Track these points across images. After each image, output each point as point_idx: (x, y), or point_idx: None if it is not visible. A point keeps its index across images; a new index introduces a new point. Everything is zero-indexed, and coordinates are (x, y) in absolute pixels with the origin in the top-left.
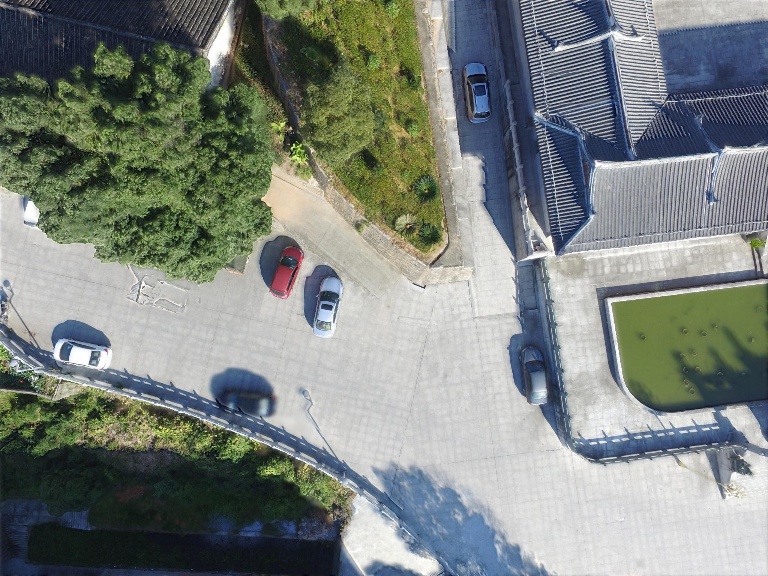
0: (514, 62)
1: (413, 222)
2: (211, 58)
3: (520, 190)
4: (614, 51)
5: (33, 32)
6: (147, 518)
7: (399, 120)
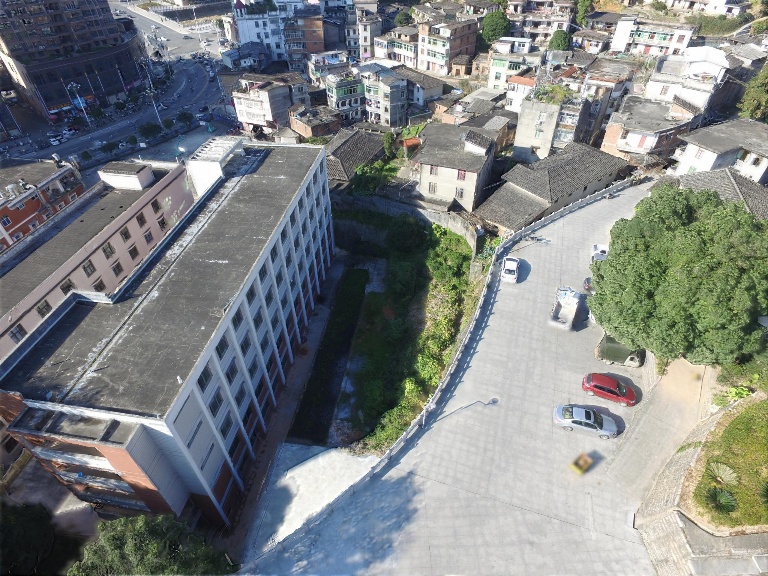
0: None
1: (728, 483)
2: None
3: None
4: None
5: None
6: (370, 320)
7: None
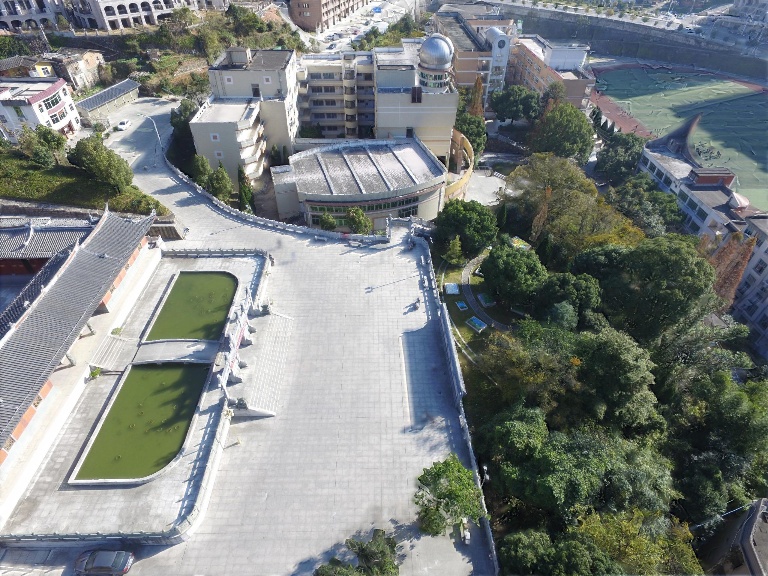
0: None
1: None
2: None
3: None
4: None
5: None
6: None
7: None
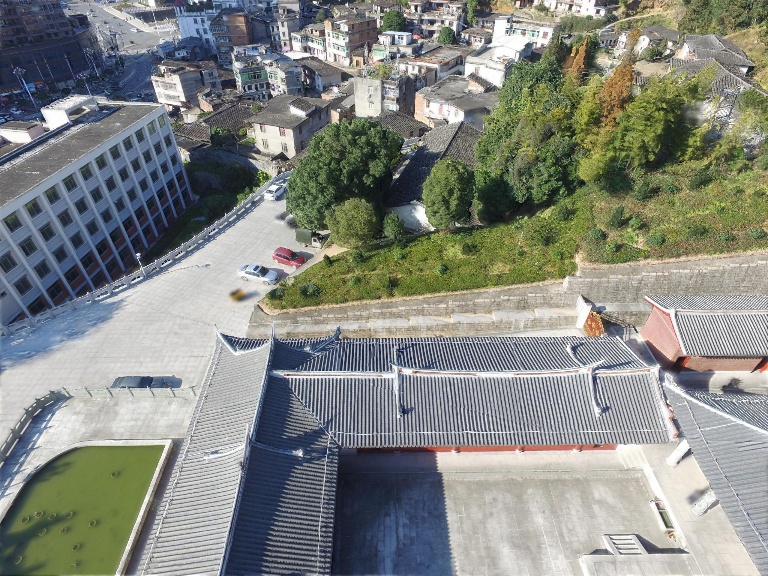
0: None
1: None
2: (420, 214)
3: None
4: None
5: None
6: (183, 237)
7: None
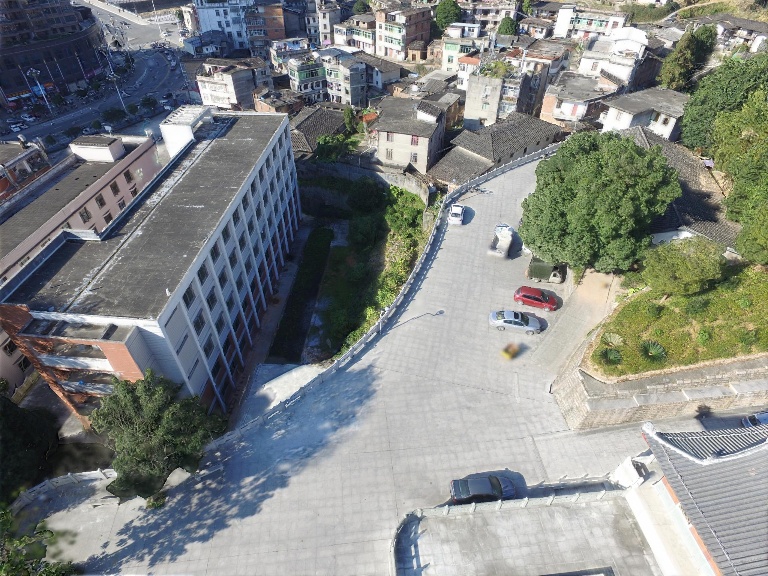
0: None
1: (617, 345)
2: None
3: None
4: None
5: None
6: (335, 268)
7: (705, 326)
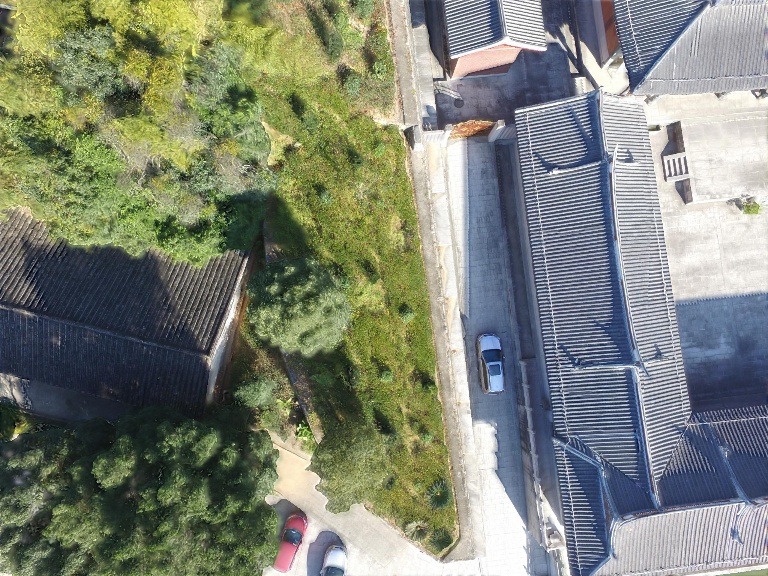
0: (530, 333)
1: (424, 527)
2: None
3: (534, 476)
4: (638, 386)
5: (27, 329)
6: None
7: (411, 428)
